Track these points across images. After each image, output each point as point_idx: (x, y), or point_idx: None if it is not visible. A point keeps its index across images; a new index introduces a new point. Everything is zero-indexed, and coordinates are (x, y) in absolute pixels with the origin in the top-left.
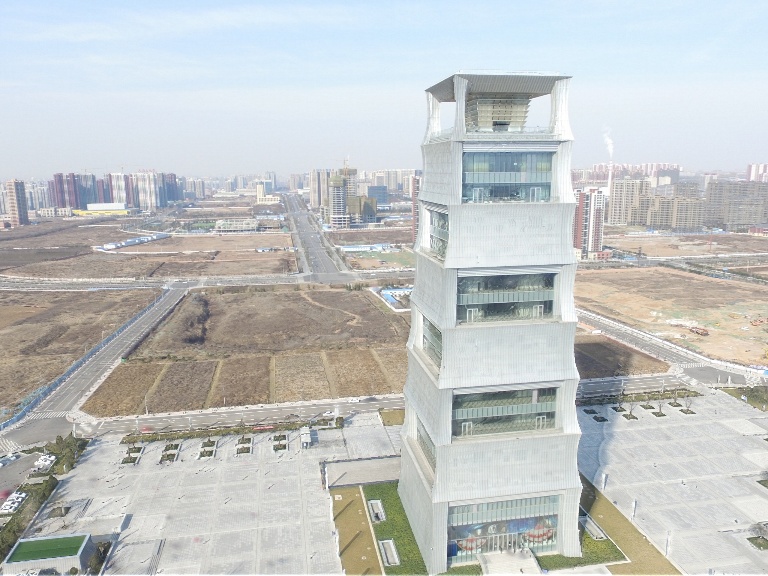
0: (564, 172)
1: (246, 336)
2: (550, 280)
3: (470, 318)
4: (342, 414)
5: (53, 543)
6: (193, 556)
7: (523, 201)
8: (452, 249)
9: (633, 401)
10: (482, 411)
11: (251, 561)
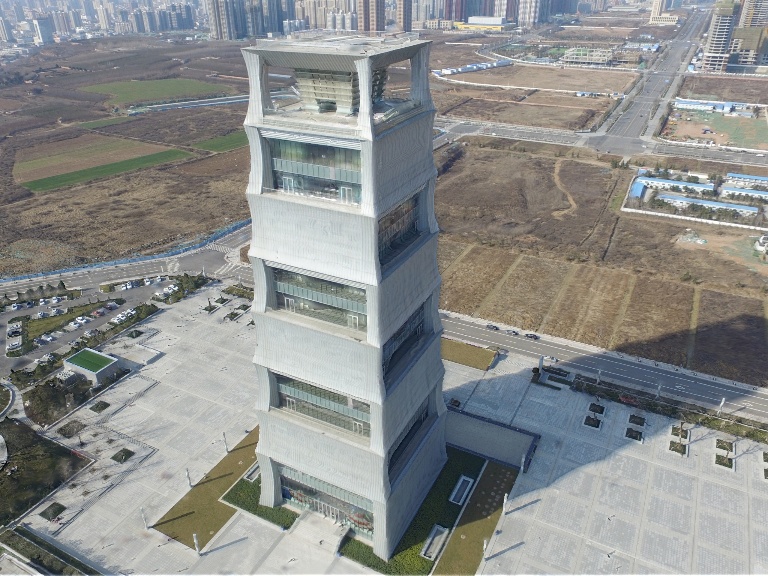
0: (366, 177)
1: (443, 205)
2: (365, 293)
3: (288, 306)
4: None
5: (97, 358)
6: (158, 403)
7: (335, 200)
8: (255, 237)
9: (718, 429)
10: (303, 394)
11: (180, 425)
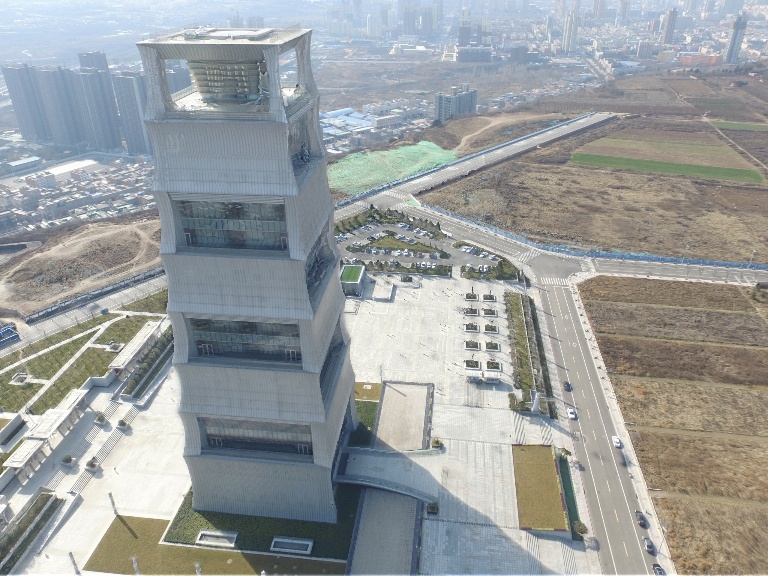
0: None
1: None
2: None
3: None
4: (573, 425)
5: None
6: None
7: None
8: None
9: None
10: None
11: None
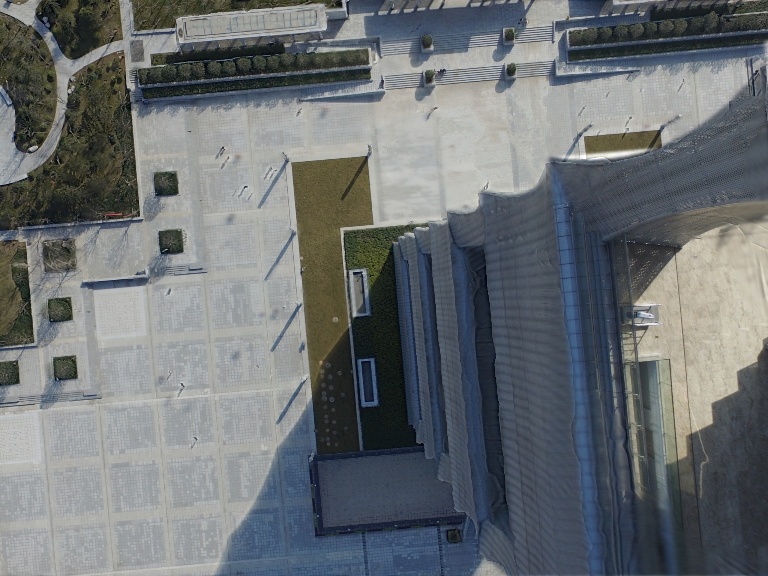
0: None
1: None
2: None
3: None
4: None
5: None
6: None
7: None
8: None
9: None
10: None
11: None
